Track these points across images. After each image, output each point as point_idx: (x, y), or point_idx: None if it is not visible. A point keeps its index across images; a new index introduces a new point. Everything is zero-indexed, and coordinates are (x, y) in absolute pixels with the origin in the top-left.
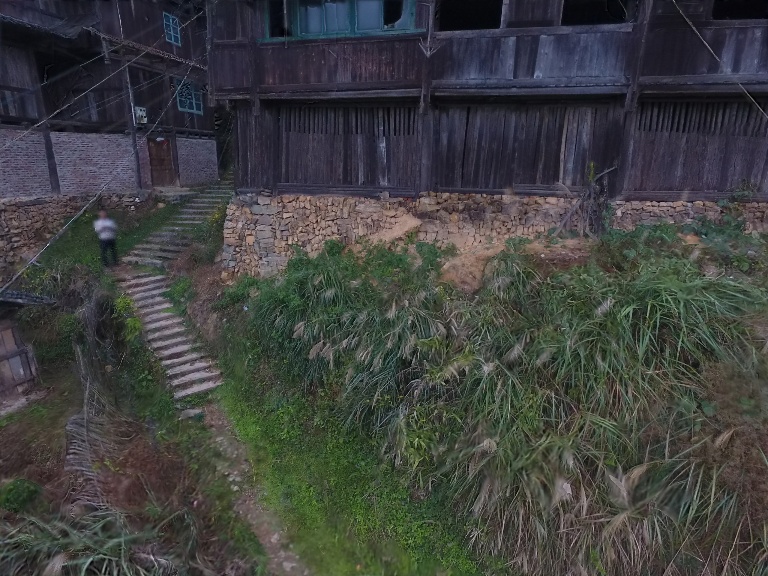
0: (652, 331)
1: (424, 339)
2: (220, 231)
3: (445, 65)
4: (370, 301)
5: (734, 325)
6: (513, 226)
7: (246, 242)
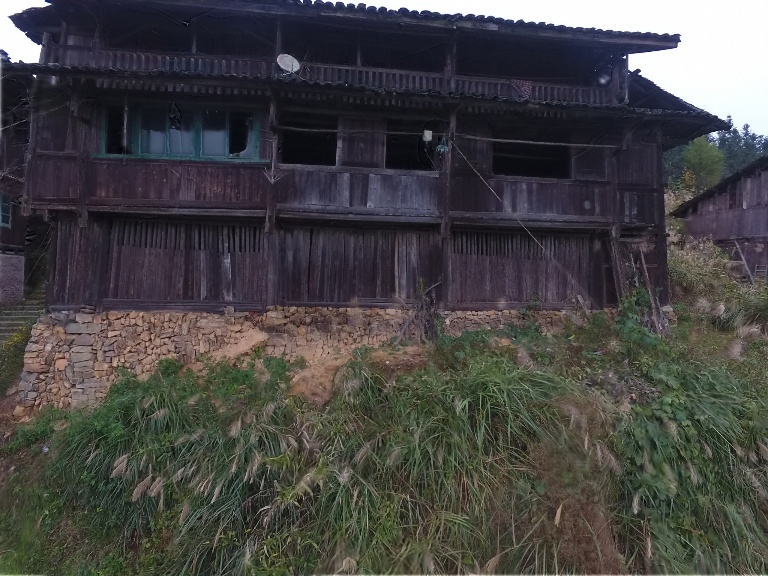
0: (486, 421)
1: (274, 457)
2: (19, 356)
3: (288, 191)
4: (212, 423)
5: (546, 408)
6: (359, 336)
7: (55, 367)
